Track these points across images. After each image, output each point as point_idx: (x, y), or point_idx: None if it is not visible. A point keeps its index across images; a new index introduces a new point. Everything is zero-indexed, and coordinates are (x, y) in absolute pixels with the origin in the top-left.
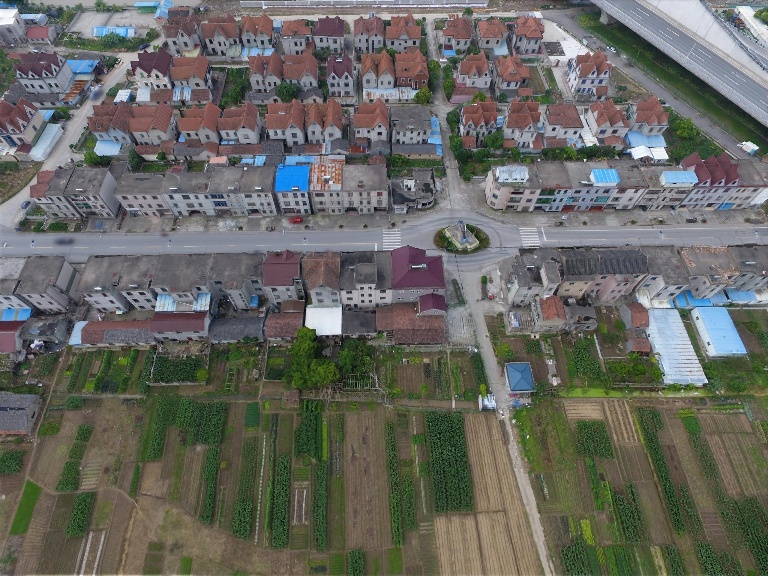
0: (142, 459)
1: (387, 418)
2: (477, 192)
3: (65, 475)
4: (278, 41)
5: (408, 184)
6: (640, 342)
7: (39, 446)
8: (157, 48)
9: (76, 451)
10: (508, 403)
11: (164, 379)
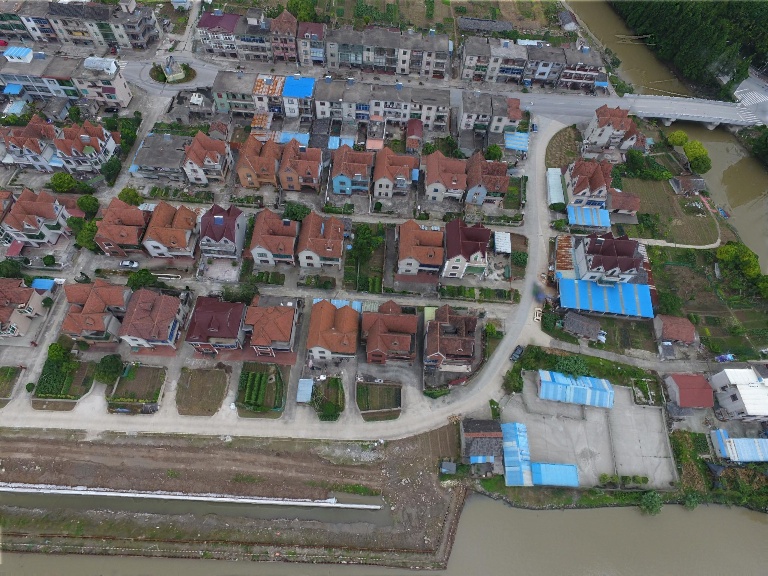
0: (396, 6)
1: (266, 3)
2: (135, 107)
3: (432, 4)
4: (307, 355)
5: (197, 97)
6: (93, 3)
7: (451, 15)
8: (488, 325)
9: (430, 10)
10: (194, 0)
11: (391, 27)
